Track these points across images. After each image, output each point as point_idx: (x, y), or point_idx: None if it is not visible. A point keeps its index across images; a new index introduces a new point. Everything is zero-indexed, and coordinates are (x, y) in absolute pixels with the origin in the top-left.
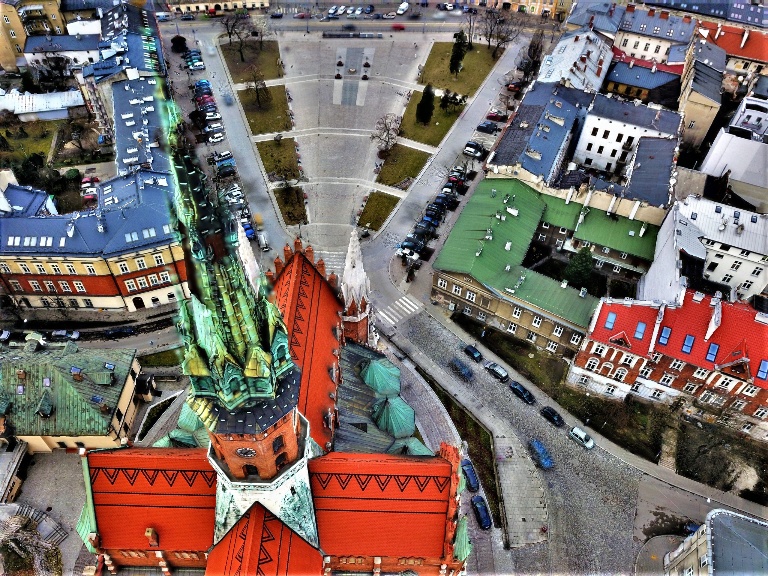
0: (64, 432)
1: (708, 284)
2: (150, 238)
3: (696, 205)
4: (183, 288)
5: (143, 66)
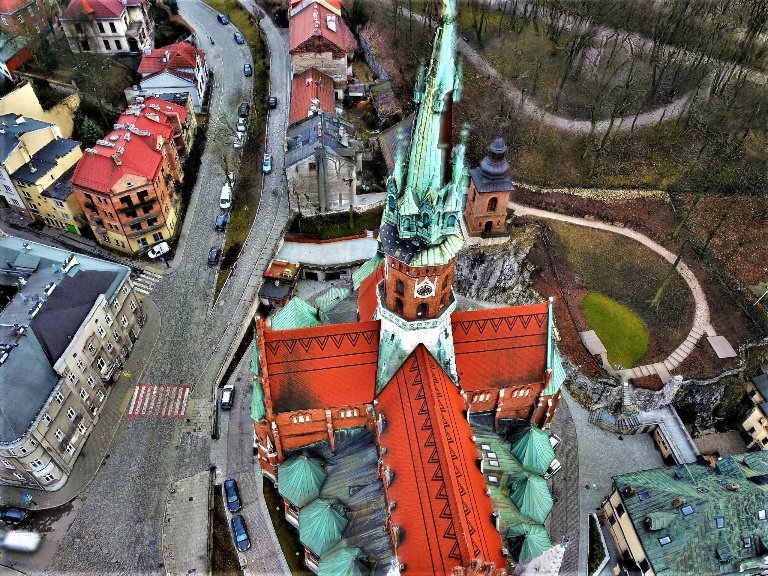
0: (652, 471)
1: None
2: None
3: None
4: None
5: None
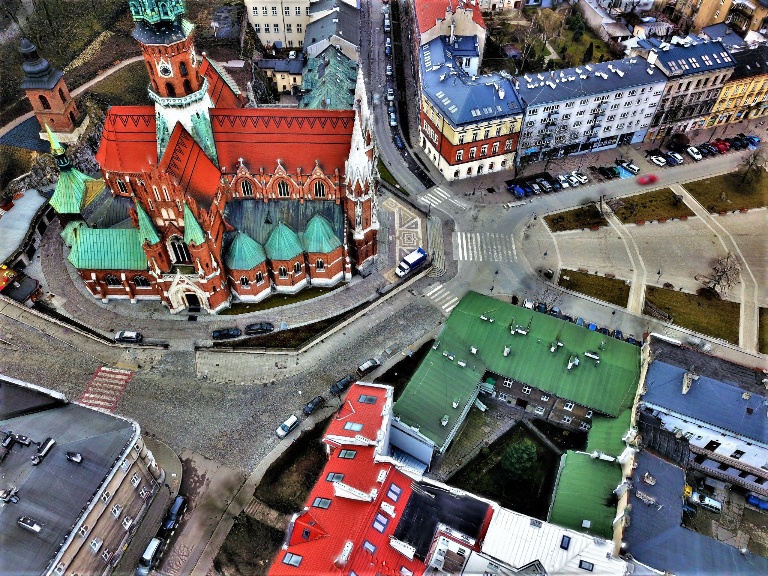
0: None
1: (426, 524)
2: (442, 103)
3: (611, 572)
4: (440, 159)
5: (669, 60)
